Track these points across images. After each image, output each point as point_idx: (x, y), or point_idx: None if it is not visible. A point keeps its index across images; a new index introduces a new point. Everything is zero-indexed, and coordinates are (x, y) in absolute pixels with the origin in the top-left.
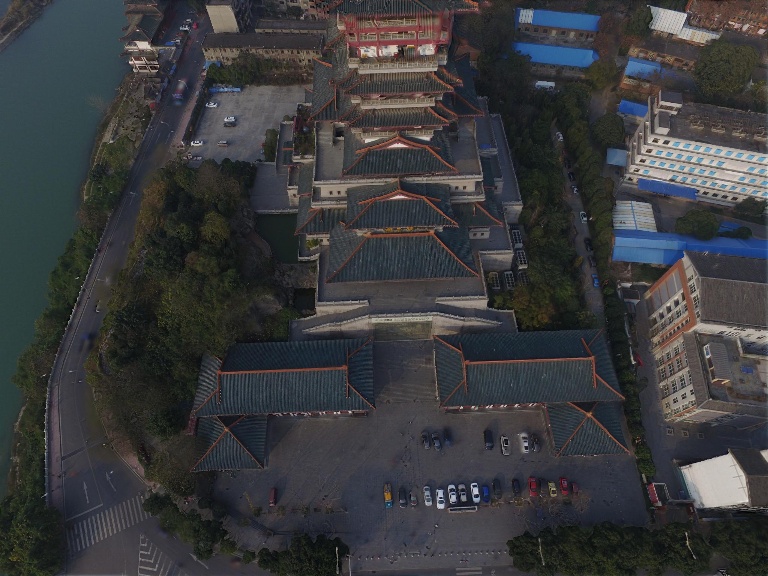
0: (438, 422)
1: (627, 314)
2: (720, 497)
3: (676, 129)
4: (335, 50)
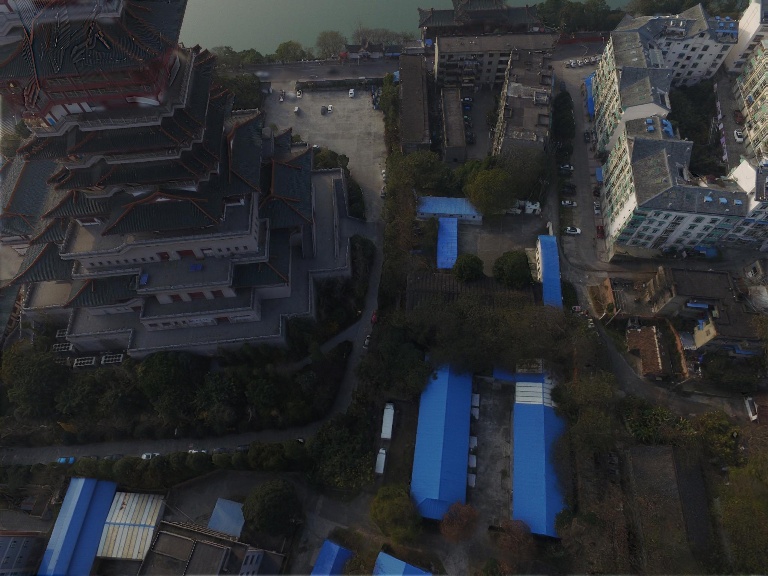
0: None
1: (7, 487)
2: None
3: (167, 573)
4: None
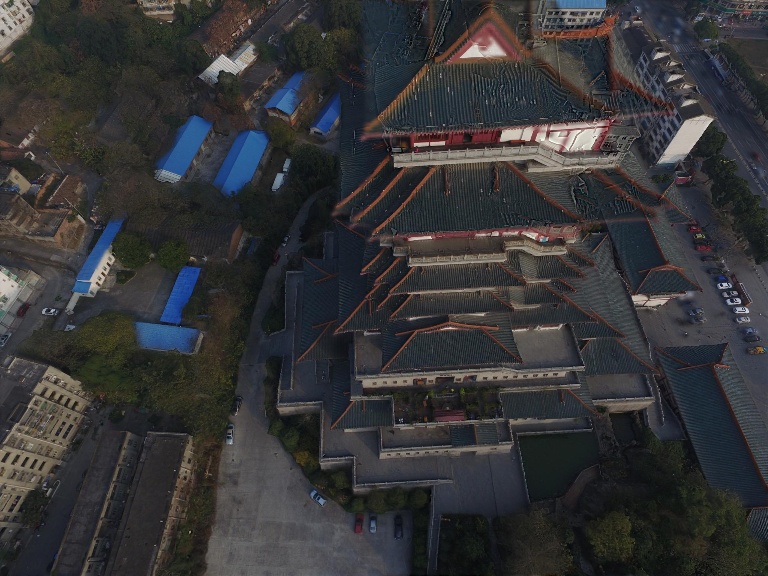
0: (677, 311)
1: None
2: (695, 139)
3: None
4: (522, 275)
